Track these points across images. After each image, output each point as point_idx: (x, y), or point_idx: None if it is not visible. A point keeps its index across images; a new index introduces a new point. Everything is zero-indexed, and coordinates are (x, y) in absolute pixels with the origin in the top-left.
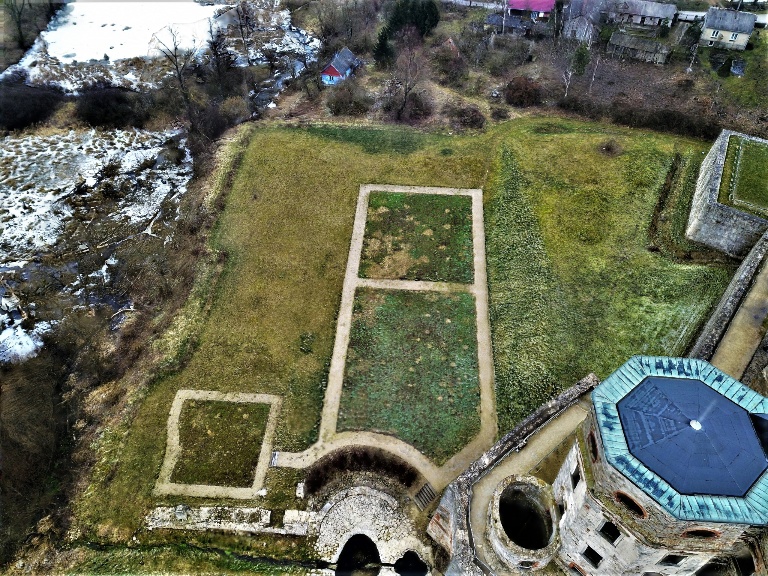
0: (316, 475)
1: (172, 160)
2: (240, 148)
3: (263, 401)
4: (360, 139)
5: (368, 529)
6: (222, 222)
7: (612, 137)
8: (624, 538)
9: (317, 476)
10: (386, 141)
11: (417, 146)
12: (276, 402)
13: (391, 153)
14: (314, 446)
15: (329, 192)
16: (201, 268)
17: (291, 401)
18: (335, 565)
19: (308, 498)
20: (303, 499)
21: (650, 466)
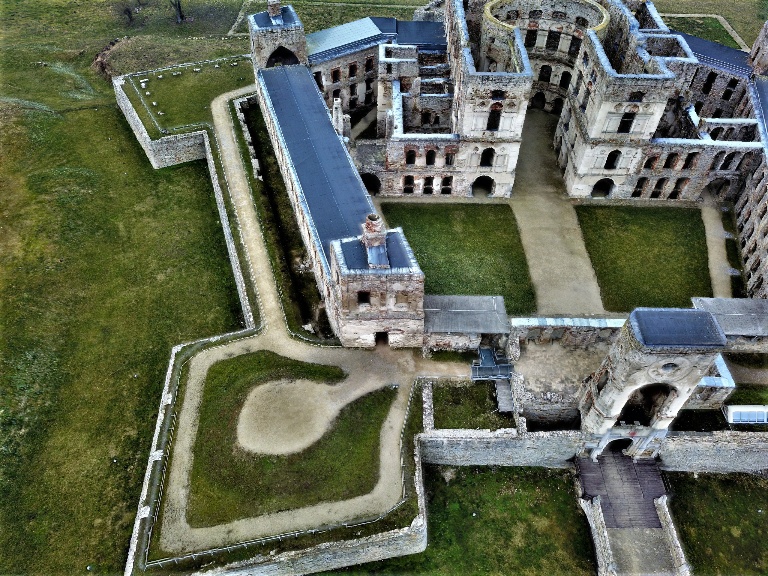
0: None
1: None
2: None
3: None
4: None
5: None
6: None
7: None
8: None
9: None
10: None
11: None
12: None
13: None
14: None
15: (702, 6)
16: None
17: None
18: None
19: None
20: None
21: None
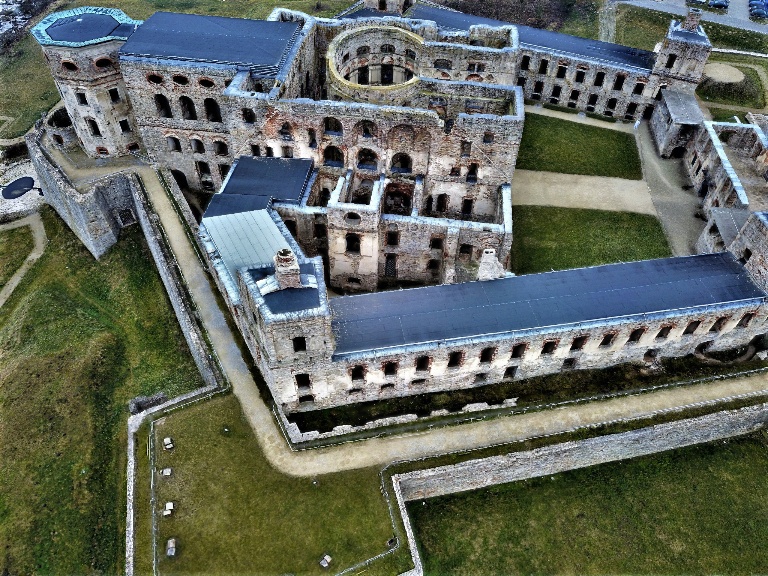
0: (14, 149)
1: (22, 11)
2: (67, 2)
3: (3, 119)
4: (155, 0)
5: (34, 175)
6: (29, 38)
7: (329, 2)
8: (60, 88)
9: (14, 150)
10: (173, 2)
11: (194, 6)
12: (10, 120)
13: (172, 9)
14: (20, 137)
15: None
16: (2, 60)
17: (18, 119)
18: (5, 187)
19: (5, 160)
20: (1, 159)
21: (49, 33)
